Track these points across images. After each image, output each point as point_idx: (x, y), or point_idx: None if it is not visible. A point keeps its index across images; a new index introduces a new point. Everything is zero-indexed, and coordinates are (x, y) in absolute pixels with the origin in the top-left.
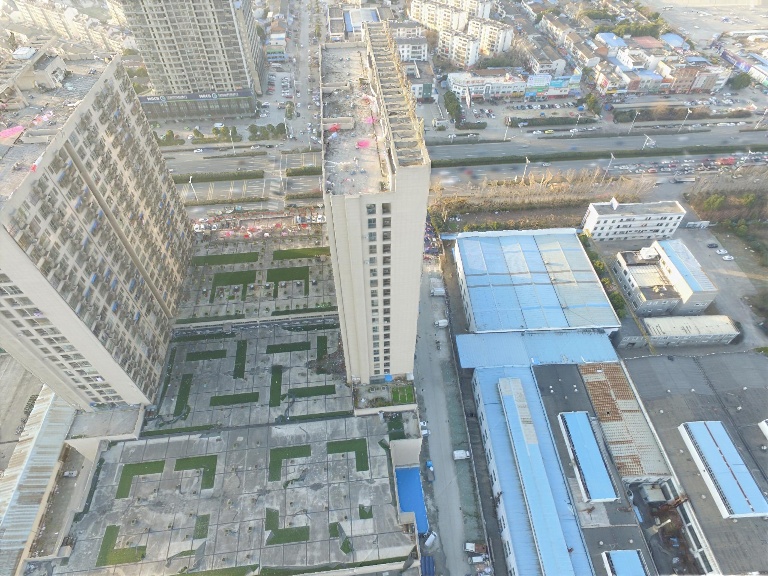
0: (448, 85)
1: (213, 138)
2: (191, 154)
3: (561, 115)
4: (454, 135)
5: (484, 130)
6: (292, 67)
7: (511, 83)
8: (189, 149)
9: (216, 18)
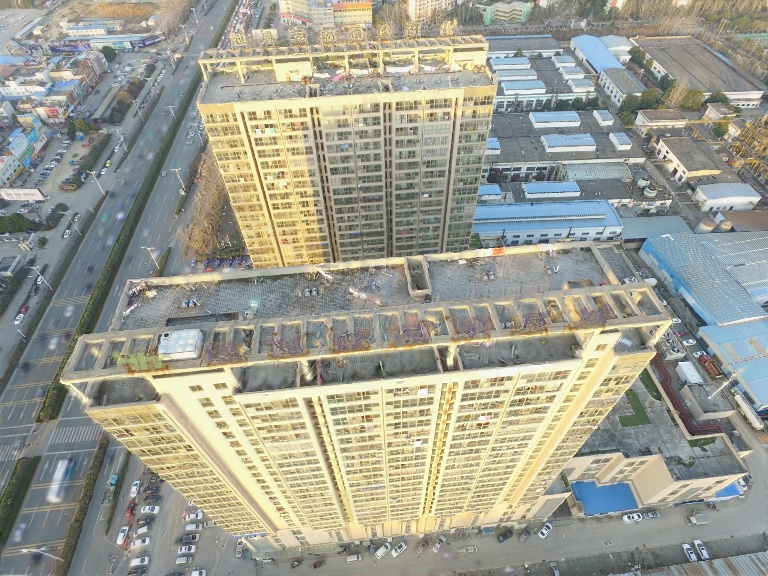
0: None
1: None
2: None
3: (81, 152)
4: (67, 231)
5: (71, 208)
6: None
7: (3, 166)
8: None
9: None
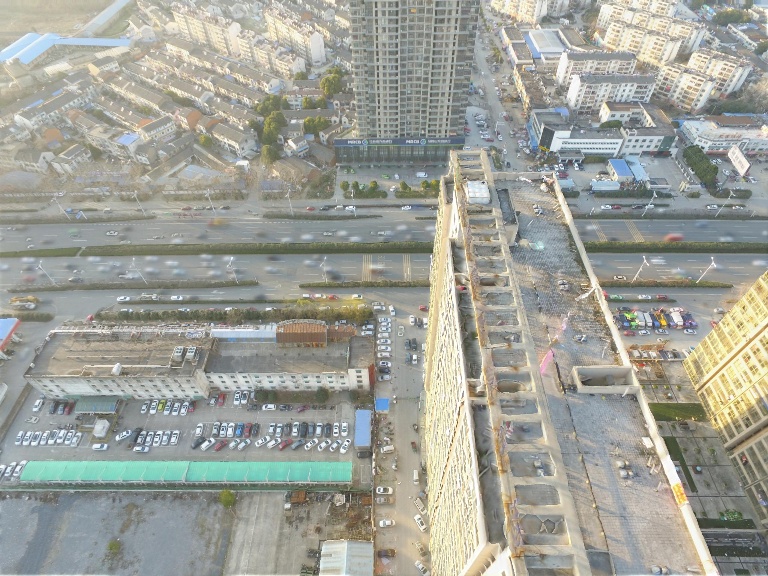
0: (684, 135)
1: (419, 191)
2: (399, 212)
3: None
4: (715, 206)
5: (749, 200)
6: (480, 100)
7: None
8: (395, 205)
9: (455, 57)
